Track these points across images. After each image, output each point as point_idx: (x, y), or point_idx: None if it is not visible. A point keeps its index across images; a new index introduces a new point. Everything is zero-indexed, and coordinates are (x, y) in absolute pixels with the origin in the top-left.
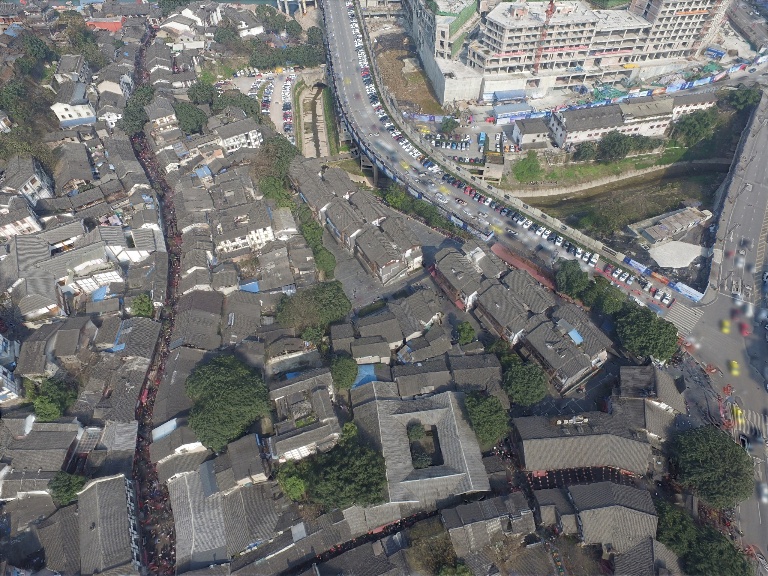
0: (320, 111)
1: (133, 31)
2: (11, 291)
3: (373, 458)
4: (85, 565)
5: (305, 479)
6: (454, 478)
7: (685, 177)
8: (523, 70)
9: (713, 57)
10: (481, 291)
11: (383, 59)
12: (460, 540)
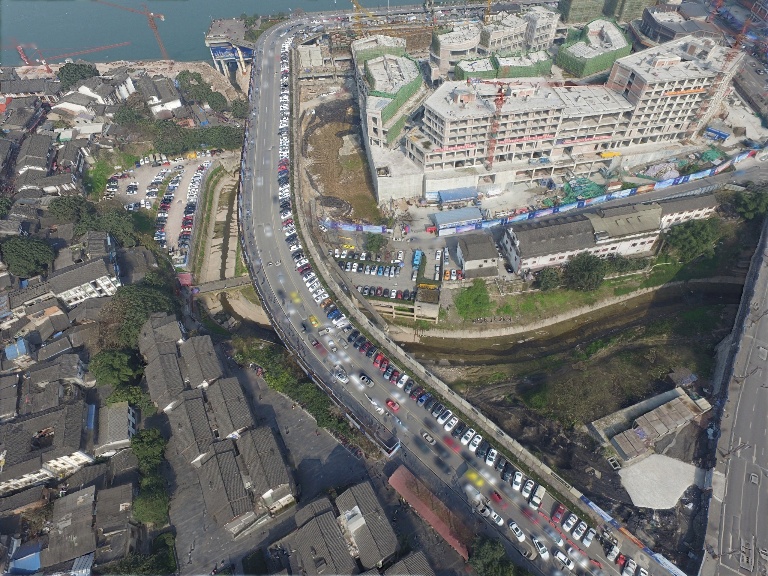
0: None
1: (17, 115)
2: None
3: None
4: None
5: None
6: None
7: (679, 305)
8: (474, 163)
9: (714, 139)
10: None
11: (320, 136)
12: None
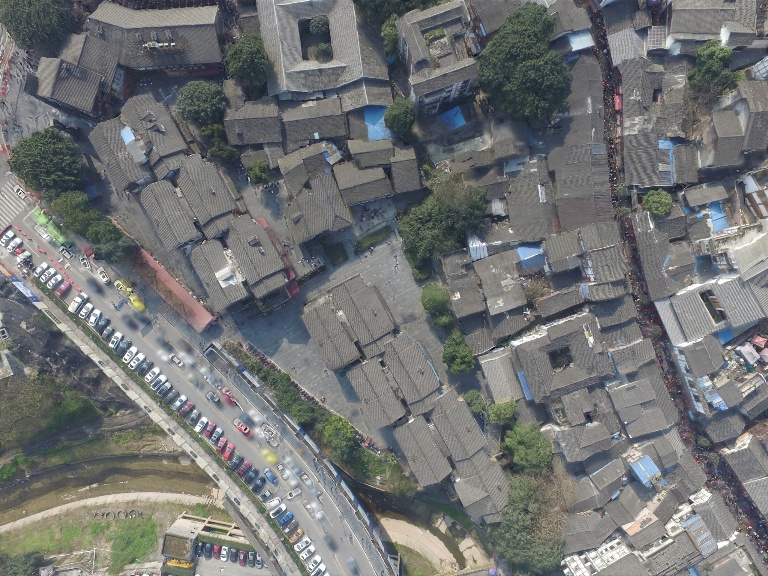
0: None
1: None
2: None
3: None
4: None
5: None
6: (289, 2)
7: None
8: None
9: None
10: (230, 217)
11: None
12: None
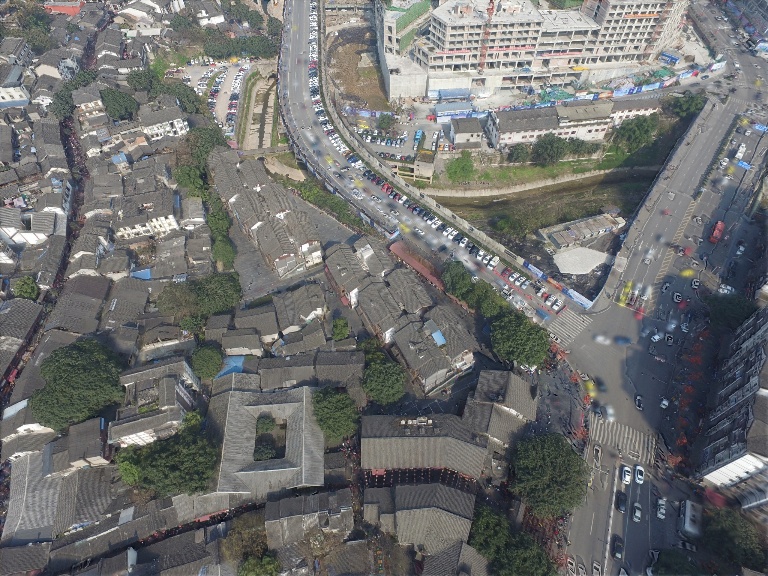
0: (272, 102)
1: (90, 16)
2: None
3: (203, 447)
4: None
5: (139, 465)
6: (289, 472)
7: (623, 183)
8: (469, 69)
9: (667, 62)
10: (361, 288)
11: (341, 53)
12: (275, 533)
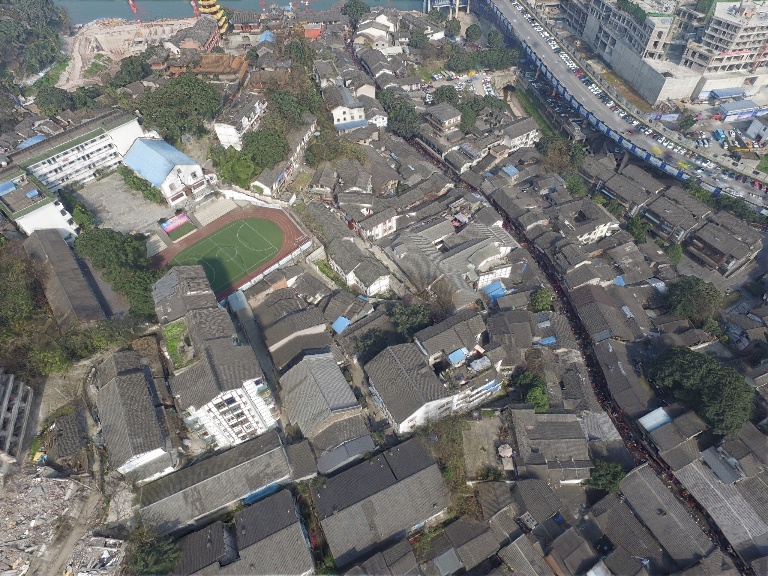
0: (518, 113)
1: (335, 37)
2: (430, 287)
3: None
4: (675, 550)
5: None
6: None
7: None
8: (740, 68)
9: None
10: None
11: None
12: None
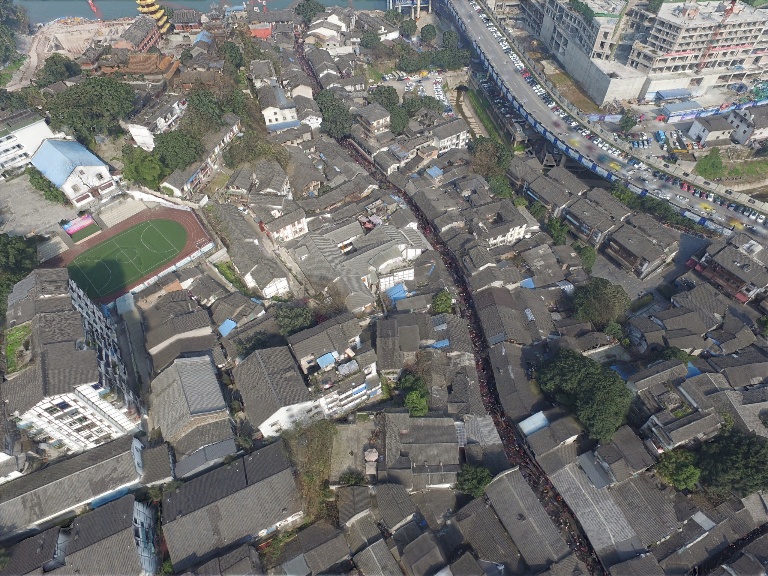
0: (469, 113)
1: (285, 37)
2: (326, 290)
3: None
4: (530, 556)
5: (698, 468)
6: None
7: None
8: (686, 69)
9: None
10: None
11: None
12: None
